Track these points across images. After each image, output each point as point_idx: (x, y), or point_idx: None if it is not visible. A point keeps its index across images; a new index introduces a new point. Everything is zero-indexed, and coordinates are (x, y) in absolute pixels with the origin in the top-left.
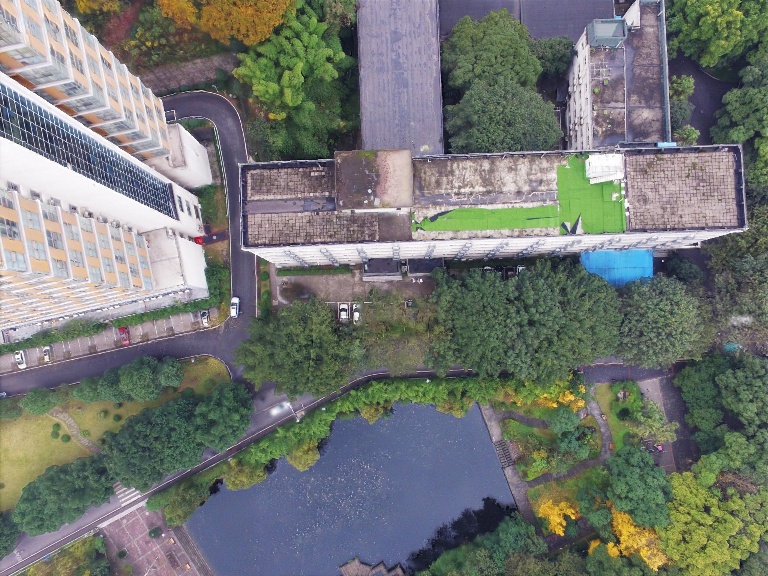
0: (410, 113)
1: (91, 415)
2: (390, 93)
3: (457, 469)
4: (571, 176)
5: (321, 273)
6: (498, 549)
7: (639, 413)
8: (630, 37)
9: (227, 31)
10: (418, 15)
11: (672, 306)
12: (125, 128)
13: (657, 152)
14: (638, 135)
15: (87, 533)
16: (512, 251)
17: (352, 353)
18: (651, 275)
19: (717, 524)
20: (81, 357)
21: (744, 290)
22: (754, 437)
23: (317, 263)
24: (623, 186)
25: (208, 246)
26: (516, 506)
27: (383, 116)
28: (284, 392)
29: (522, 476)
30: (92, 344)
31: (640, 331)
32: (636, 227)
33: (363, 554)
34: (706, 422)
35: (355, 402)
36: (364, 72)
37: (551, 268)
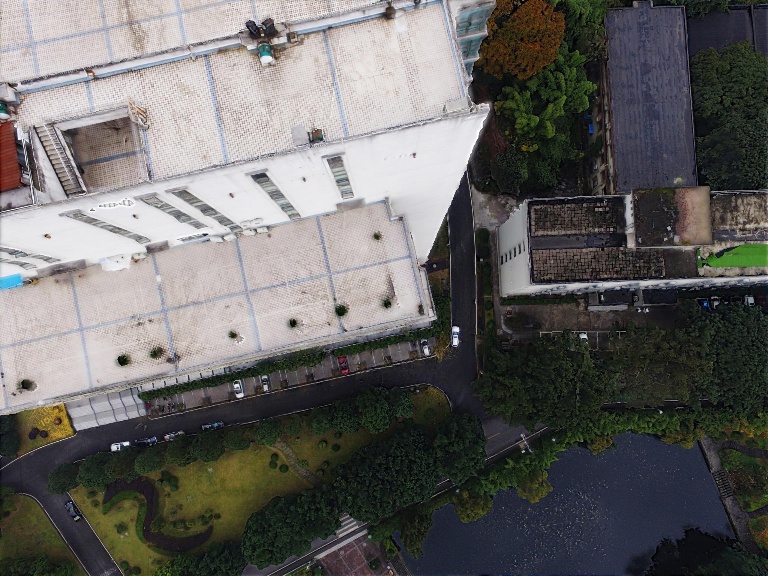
0: (662, 145)
1: (309, 445)
2: (641, 125)
3: (676, 499)
4: None
5: (546, 302)
6: None
7: None
8: None
9: (508, 66)
10: (667, 47)
11: None
12: None
13: None
14: None
15: (305, 564)
16: None
17: (609, 387)
18: None
19: None
20: (299, 386)
21: None
22: None
23: (549, 293)
24: None
25: (428, 275)
26: (735, 537)
27: (635, 148)
28: (521, 424)
29: (743, 507)
30: (309, 373)
31: None
32: None
33: None
34: None
35: (586, 433)
36: (615, 104)
37: None
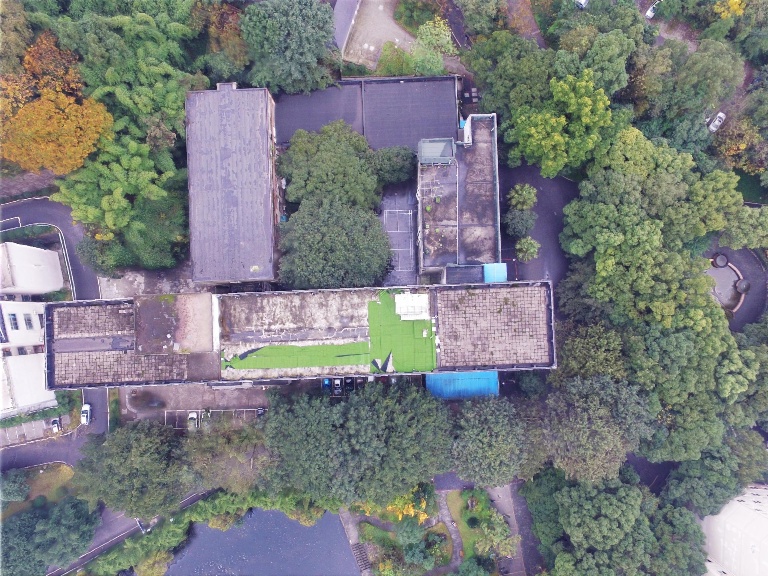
0: (240, 233)
1: None
2: (220, 212)
3: (315, 572)
4: (382, 312)
5: None
6: None
7: (484, 524)
8: (463, 153)
9: (32, 165)
10: (248, 131)
11: (491, 437)
12: None
13: (469, 287)
14: (470, 254)
15: None
16: None
17: (181, 478)
18: (496, 386)
19: None
20: None
21: (571, 414)
22: (581, 561)
23: None
24: (434, 322)
25: None
26: None
27: (212, 236)
28: None
29: None
30: None
31: None
32: (446, 364)
33: None
34: (545, 537)
35: (203, 513)
36: (193, 190)
37: (384, 388)
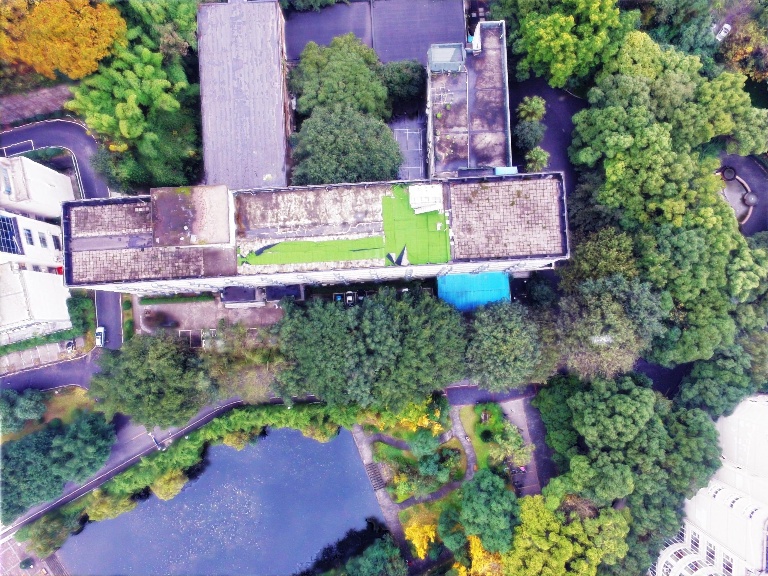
0: (252, 142)
1: None
2: (232, 122)
3: (329, 492)
4: (396, 206)
5: (183, 301)
6: (357, 574)
7: (498, 435)
8: (473, 61)
9: (48, 67)
10: (260, 42)
11: (505, 333)
12: None
13: (482, 181)
14: (481, 160)
15: None
16: (363, 277)
17: (198, 385)
18: (508, 297)
19: (554, 549)
20: None
21: None
22: (596, 460)
23: (175, 292)
24: (447, 216)
25: None
26: (389, 528)
27: (225, 145)
28: None
29: (393, 498)
30: None
31: (481, 357)
32: (461, 257)
33: None
34: (559, 444)
35: (218, 430)
36: (206, 101)
37: (397, 295)
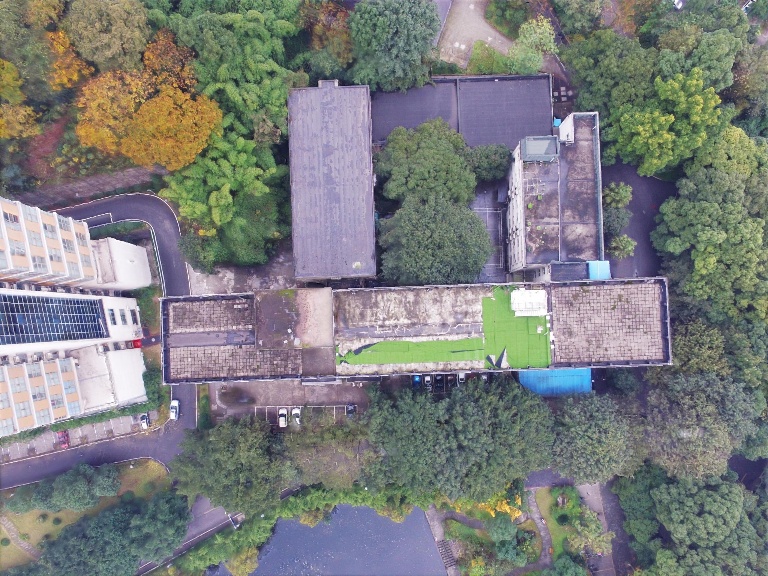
0: (342, 229)
1: (31, 518)
2: (322, 208)
3: (400, 569)
4: (496, 308)
5: None
6: None
7: (577, 521)
8: (564, 151)
9: (148, 160)
10: (350, 128)
11: (600, 434)
12: (37, 274)
13: (583, 284)
14: (572, 251)
15: None
16: None
17: (284, 473)
18: (589, 383)
19: None
20: (20, 460)
21: (675, 411)
22: (684, 558)
23: None
24: (548, 319)
25: (147, 349)
26: None
27: (315, 232)
28: None
29: None
30: (31, 447)
31: (571, 453)
32: (561, 360)
33: None
34: (641, 534)
35: (294, 509)
36: (296, 187)
37: (485, 385)
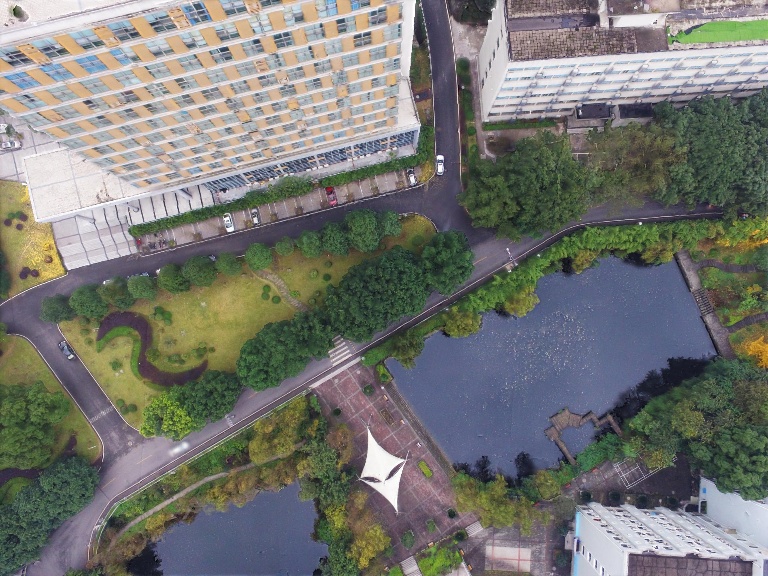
0: None
1: (301, 276)
2: None
3: (658, 318)
4: None
5: (527, 126)
6: (723, 378)
7: None
8: None
9: None
10: None
11: None
12: None
13: None
14: None
15: (300, 393)
16: (726, 88)
17: (589, 182)
18: None
19: None
20: (288, 219)
21: None
22: None
23: (529, 112)
24: None
25: None
26: (717, 352)
27: None
28: (506, 235)
29: (723, 322)
30: (298, 206)
31: None
32: None
33: (572, 404)
34: None
35: (569, 248)
36: None
37: None
